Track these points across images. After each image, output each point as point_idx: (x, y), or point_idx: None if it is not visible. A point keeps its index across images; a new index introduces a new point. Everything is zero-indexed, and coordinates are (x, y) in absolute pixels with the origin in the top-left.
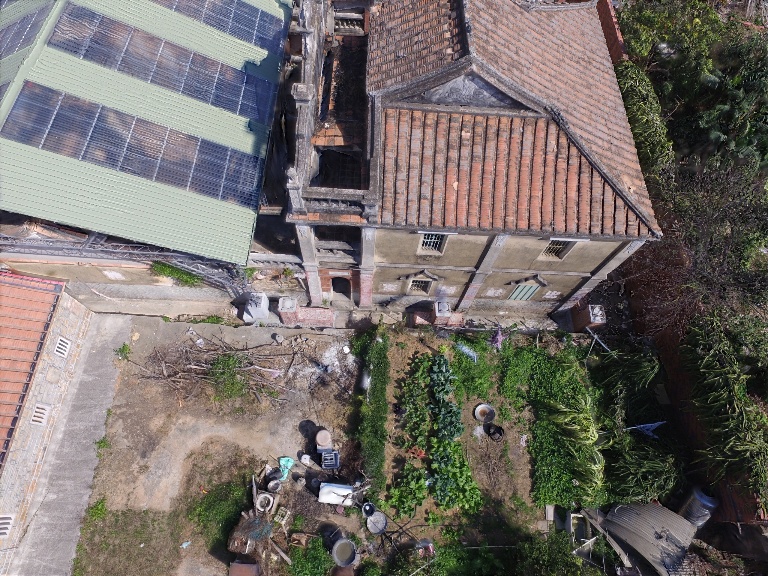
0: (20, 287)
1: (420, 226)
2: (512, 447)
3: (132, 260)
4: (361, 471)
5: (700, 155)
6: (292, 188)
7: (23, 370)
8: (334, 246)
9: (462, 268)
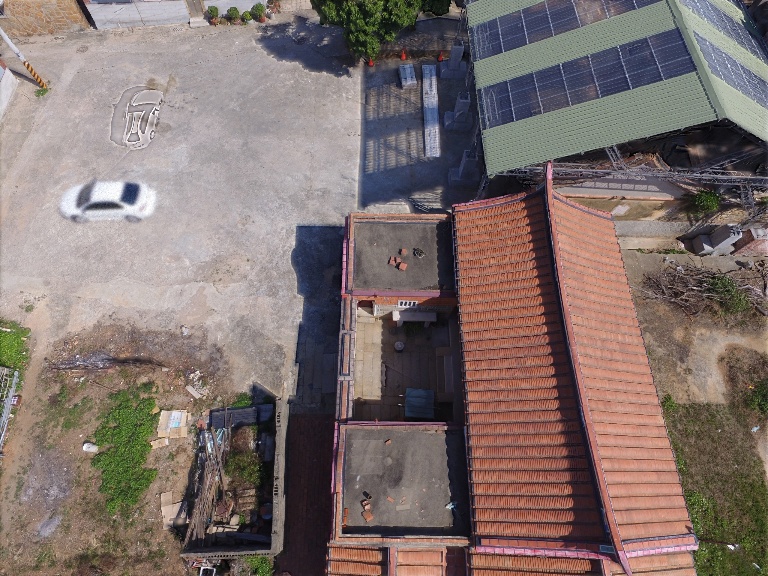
0: (591, 215)
1: None
2: None
3: None
4: None
5: None
6: None
7: (623, 282)
8: None
9: None
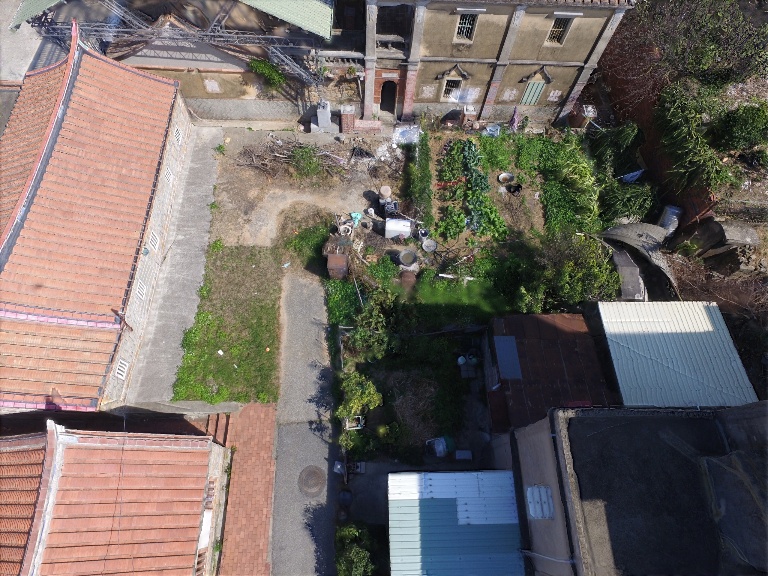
0: (149, 79)
1: None
2: (528, 200)
3: (233, 59)
4: (417, 207)
5: None
6: None
7: (160, 133)
8: (390, 38)
9: (486, 60)
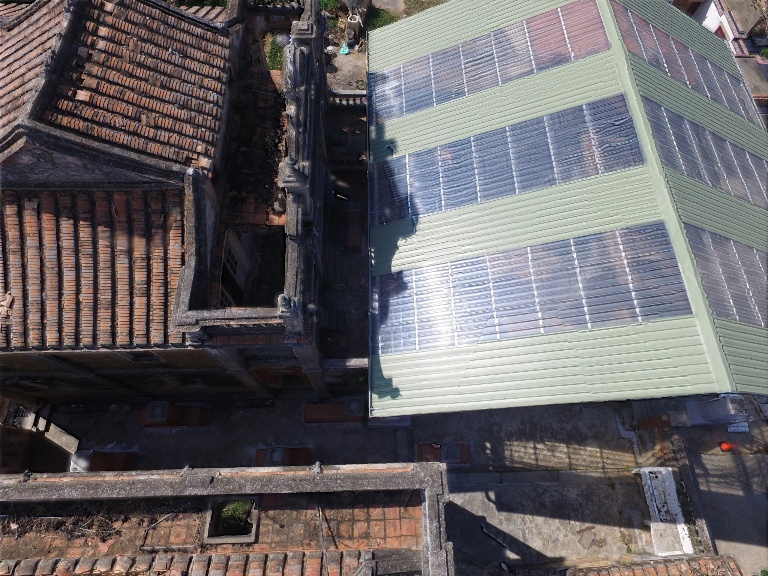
0: None
1: None
2: None
3: None
4: None
5: None
6: None
7: None
8: None
9: None
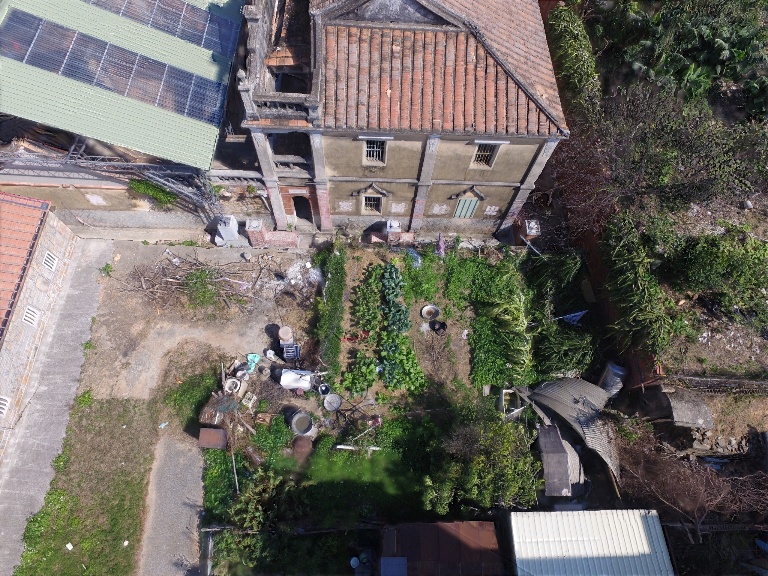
0: (10, 203)
1: (359, 129)
2: (454, 340)
3: (110, 178)
4: (318, 357)
5: (625, 87)
6: (243, 90)
7: (15, 272)
8: (289, 159)
9: (405, 180)
